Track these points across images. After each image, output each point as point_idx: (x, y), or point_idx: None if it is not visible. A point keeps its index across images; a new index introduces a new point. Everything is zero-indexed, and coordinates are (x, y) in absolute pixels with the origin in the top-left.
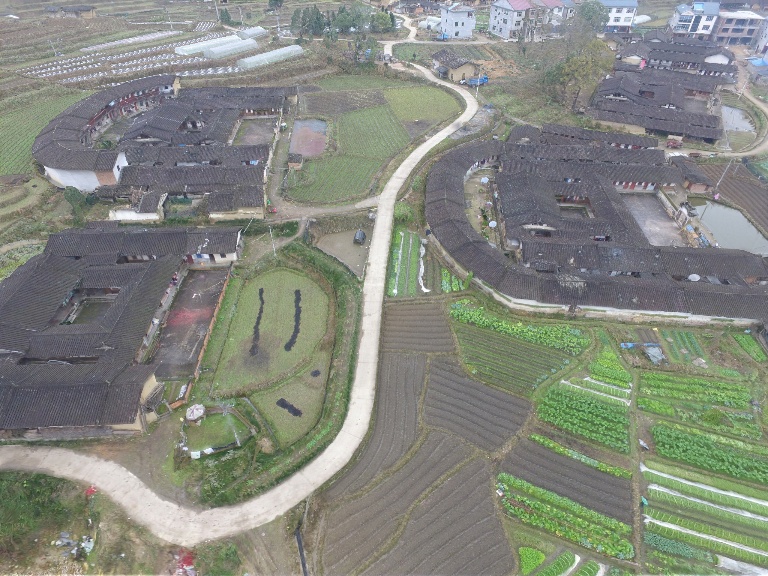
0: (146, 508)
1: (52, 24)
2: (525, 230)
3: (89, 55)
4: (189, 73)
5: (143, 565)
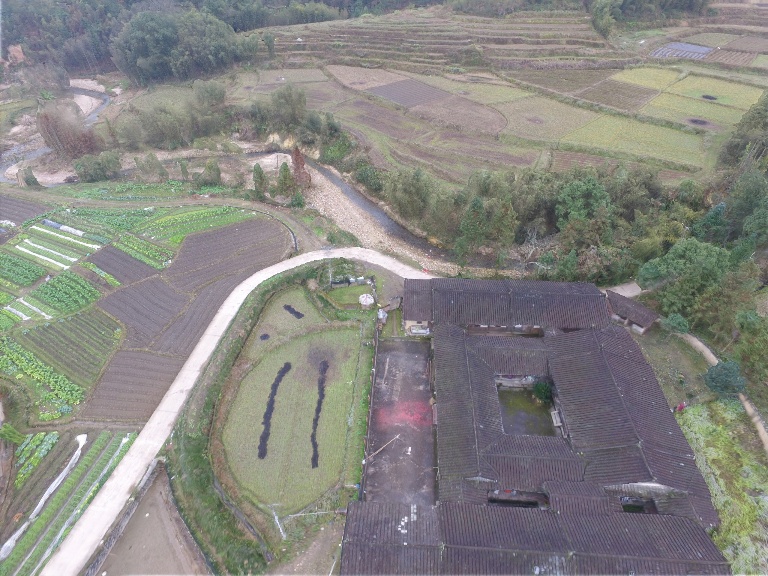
0: (386, 261)
1: None
2: None
3: None
4: None
5: None
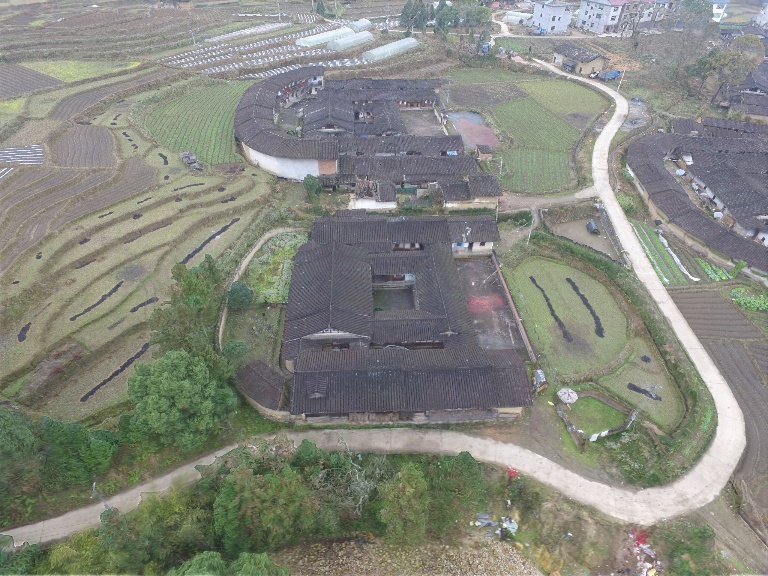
0: (580, 488)
1: (159, 15)
2: (759, 221)
3: (216, 46)
4: (319, 65)
5: (595, 544)
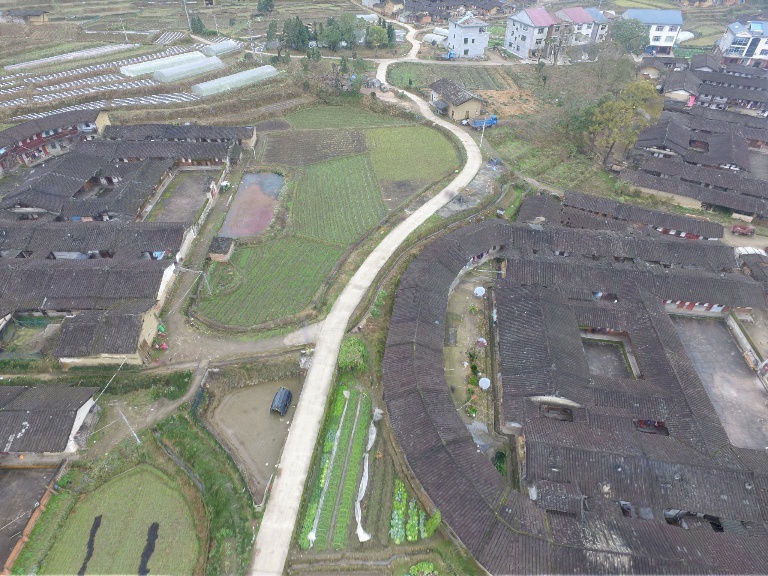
0: None
1: None
2: (533, 404)
3: (13, 75)
4: (130, 101)
5: None
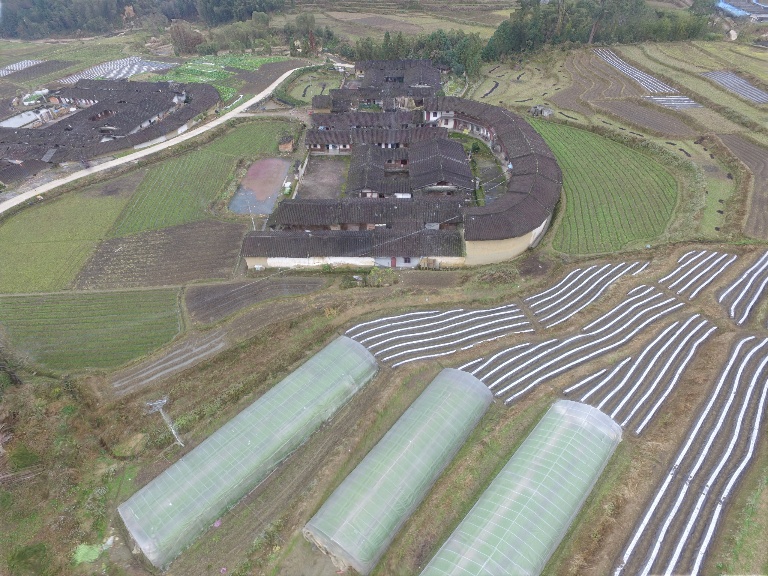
0: None
1: None
2: None
3: None
4: (492, 321)
5: None
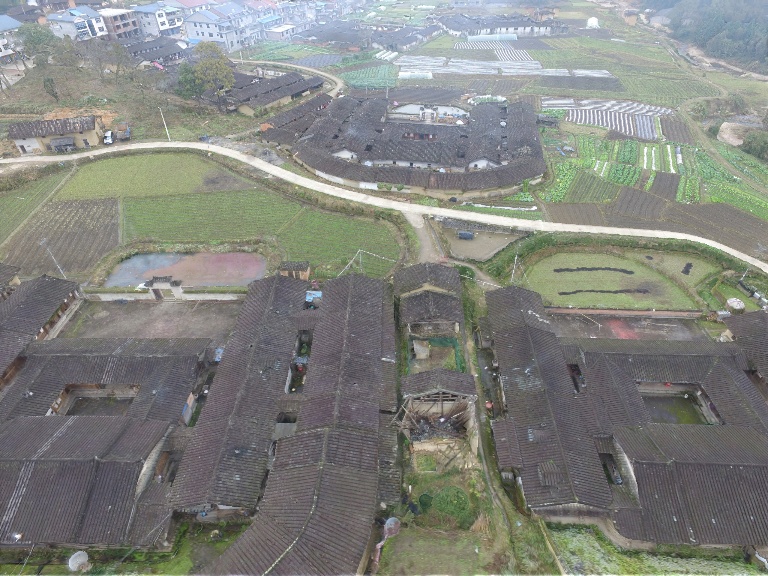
0: None
1: None
2: None
3: None
4: None
5: None
